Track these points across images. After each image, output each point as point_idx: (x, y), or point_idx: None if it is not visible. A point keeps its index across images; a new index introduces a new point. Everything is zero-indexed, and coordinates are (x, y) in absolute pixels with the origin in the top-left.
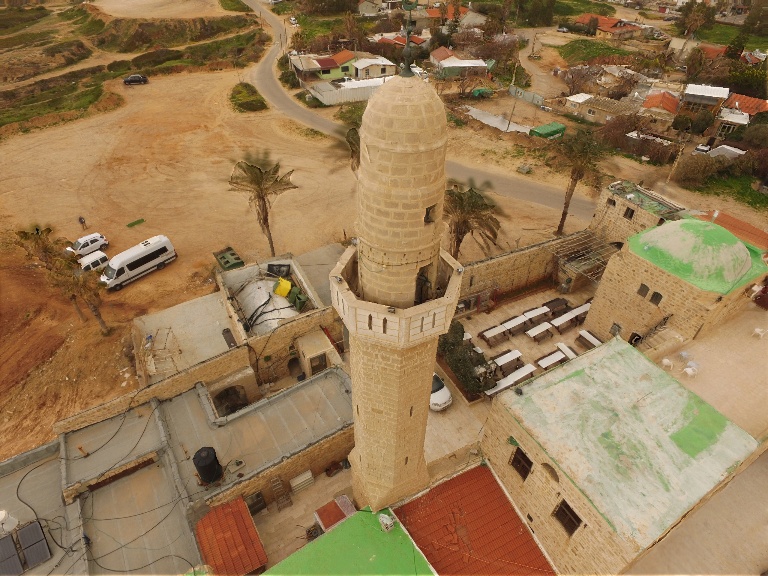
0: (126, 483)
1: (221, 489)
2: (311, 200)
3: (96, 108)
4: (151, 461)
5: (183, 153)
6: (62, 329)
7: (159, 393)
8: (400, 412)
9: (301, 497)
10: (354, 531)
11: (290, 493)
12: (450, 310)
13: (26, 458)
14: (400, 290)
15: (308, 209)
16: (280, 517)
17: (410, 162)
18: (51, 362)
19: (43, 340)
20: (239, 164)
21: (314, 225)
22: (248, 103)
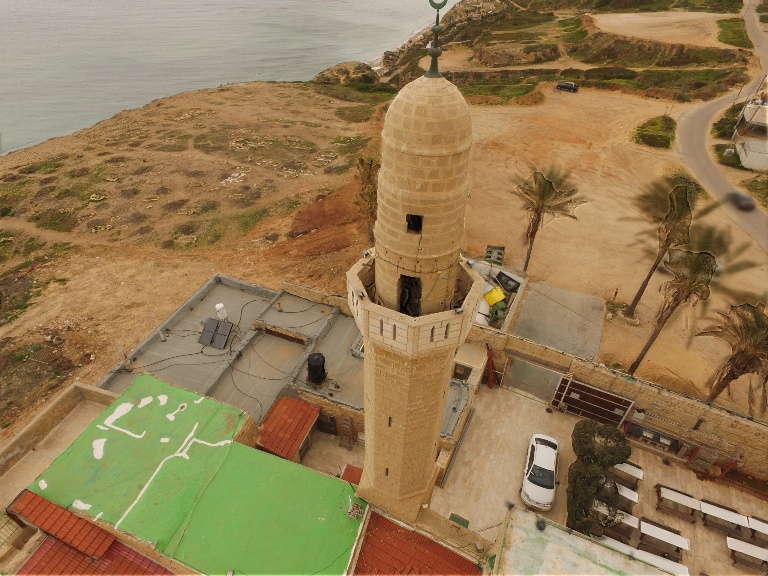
0: (283, 343)
1: (312, 391)
2: (623, 249)
3: (516, 100)
4: (303, 342)
5: (549, 159)
6: (354, 238)
7: (343, 306)
8: (378, 412)
9: (360, 452)
10: (331, 490)
11: (357, 442)
12: (412, 334)
13: (262, 291)
14: (385, 286)
15: (611, 255)
16: (336, 450)
17: (395, 159)
18: (333, 254)
19: (341, 238)
20: (535, 173)
21: (601, 272)
22: (652, 136)
